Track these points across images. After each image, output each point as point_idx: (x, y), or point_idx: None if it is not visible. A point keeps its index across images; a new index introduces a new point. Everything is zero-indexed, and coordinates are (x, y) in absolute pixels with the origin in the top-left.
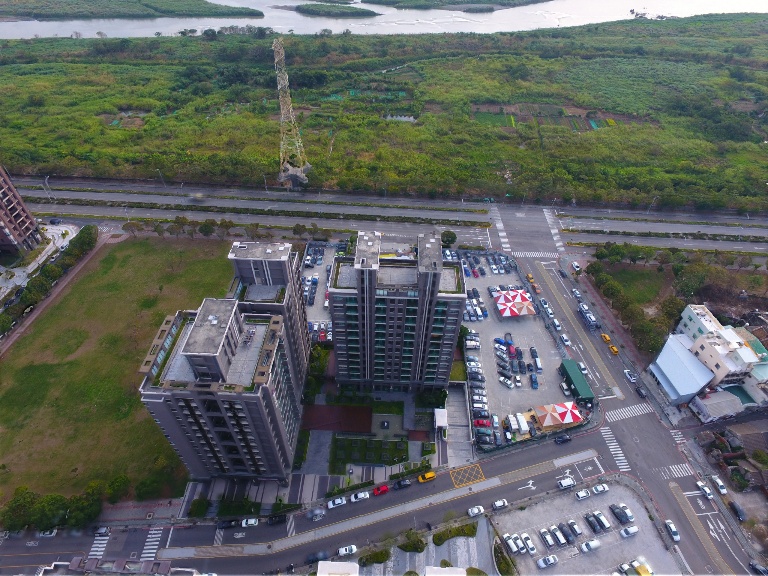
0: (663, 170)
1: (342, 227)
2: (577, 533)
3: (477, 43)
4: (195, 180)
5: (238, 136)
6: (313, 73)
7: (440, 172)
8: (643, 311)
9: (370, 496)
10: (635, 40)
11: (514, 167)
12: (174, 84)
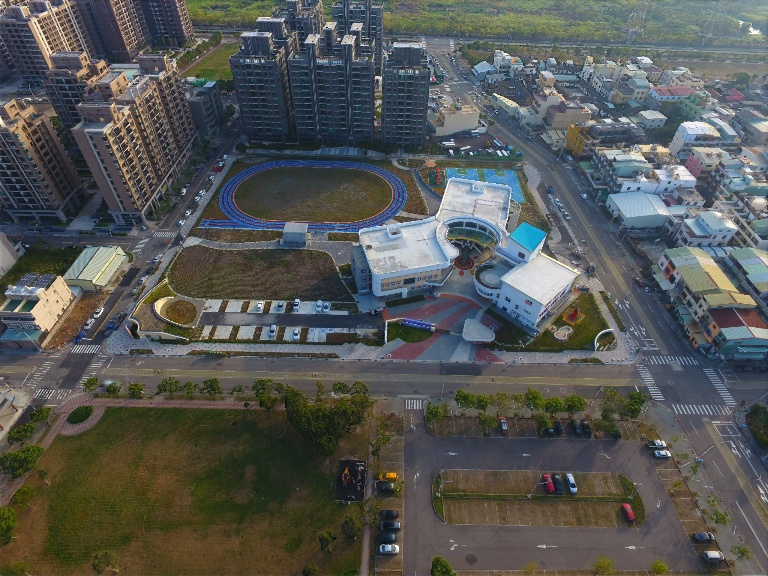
0: None
1: None
2: None
3: None
4: None
5: None
6: None
7: None
8: None
9: None
10: None
11: None
12: None
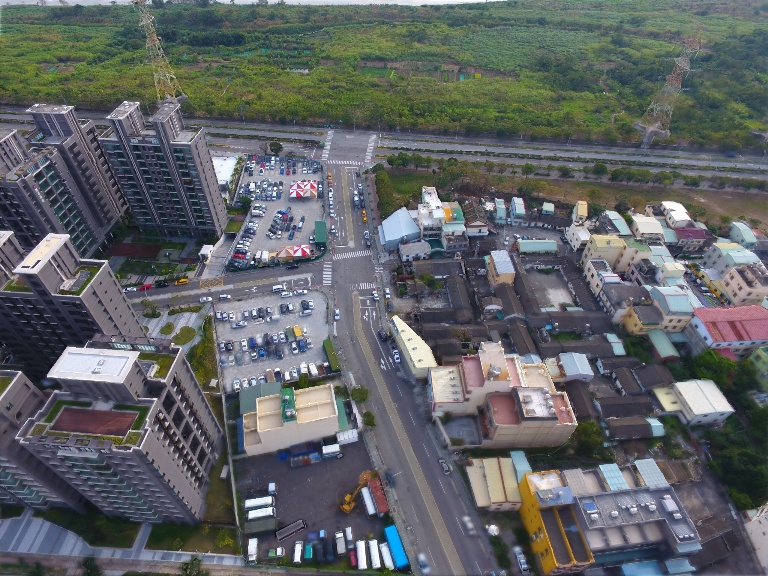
0: (496, 111)
1: None
2: (268, 312)
3: (396, 13)
4: (93, 106)
5: (149, 80)
6: (231, 33)
7: (300, 106)
8: (390, 192)
9: (137, 290)
10: (543, 12)
11: None
12: (111, 41)
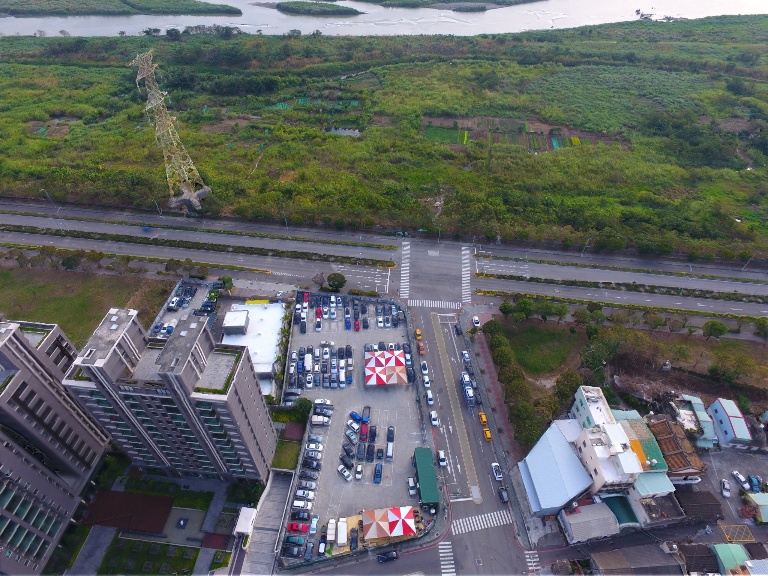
0: (618, 201)
1: (227, 262)
2: None
3: (453, 47)
4: (84, 202)
5: (160, 149)
6: (261, 79)
7: (359, 198)
8: (527, 389)
9: None
10: (629, 45)
11: (450, 192)
12: (116, 89)
